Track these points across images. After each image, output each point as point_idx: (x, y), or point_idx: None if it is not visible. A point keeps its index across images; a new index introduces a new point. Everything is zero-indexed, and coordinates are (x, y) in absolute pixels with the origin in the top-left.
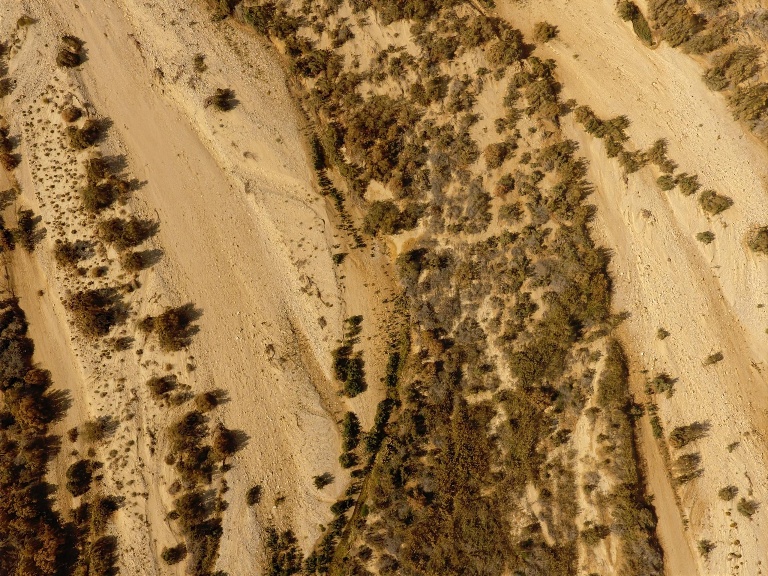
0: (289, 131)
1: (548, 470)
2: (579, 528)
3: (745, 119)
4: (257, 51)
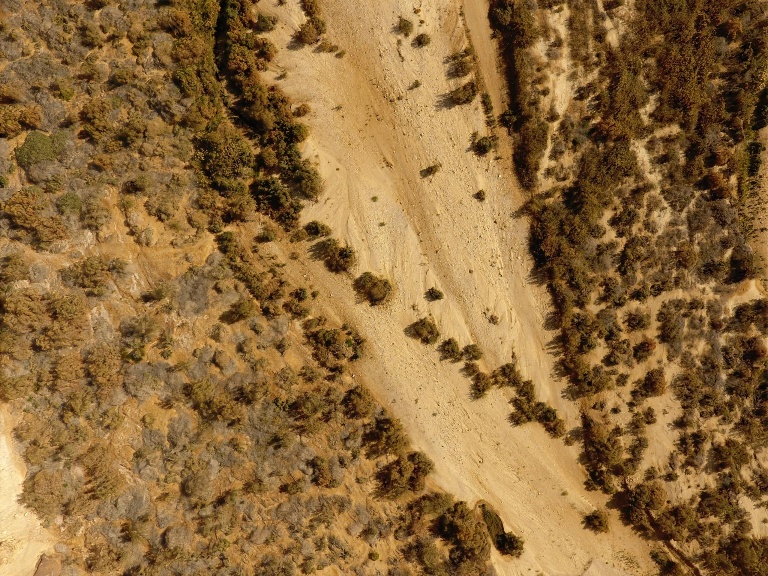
0: None
1: None
2: (566, 6)
3: None
4: None
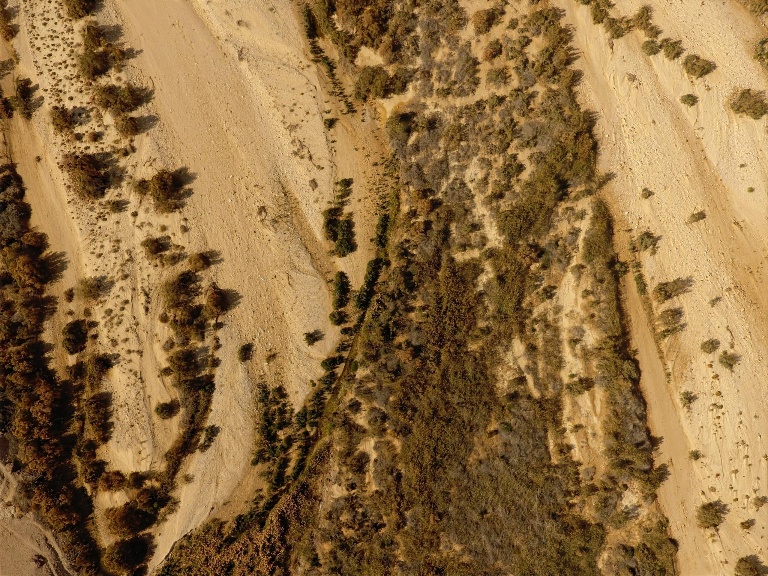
0: (282, 1)
1: (534, 325)
2: (564, 381)
3: None
4: None
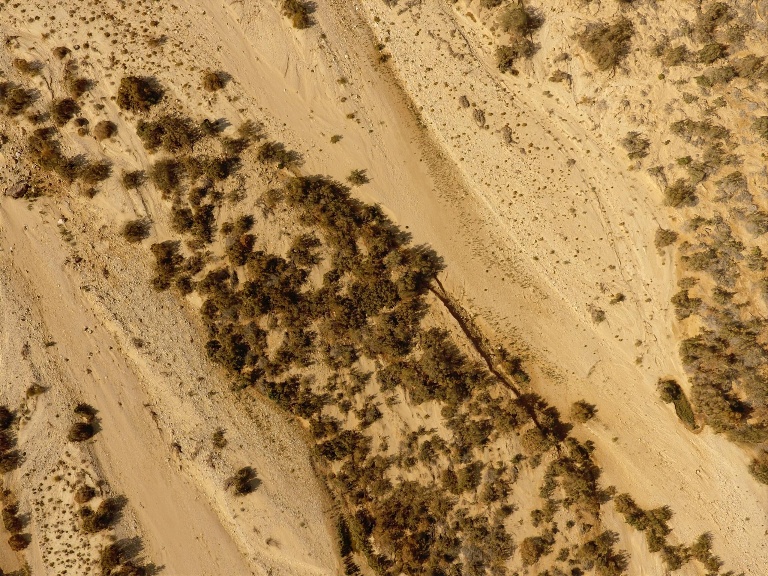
0: (314, 513)
1: None
2: None
3: None
4: (280, 425)
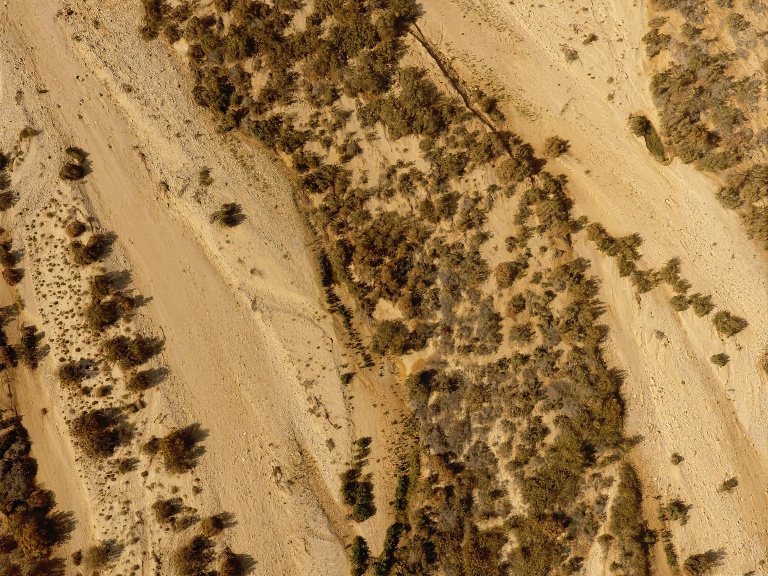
0: (296, 246)
1: None
2: None
3: (760, 239)
4: (264, 164)
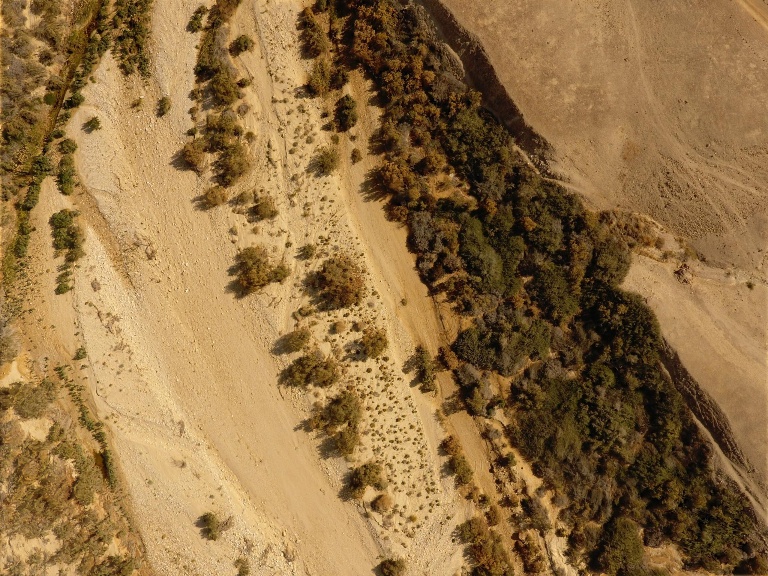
0: (140, 493)
1: None
2: None
3: None
4: None
